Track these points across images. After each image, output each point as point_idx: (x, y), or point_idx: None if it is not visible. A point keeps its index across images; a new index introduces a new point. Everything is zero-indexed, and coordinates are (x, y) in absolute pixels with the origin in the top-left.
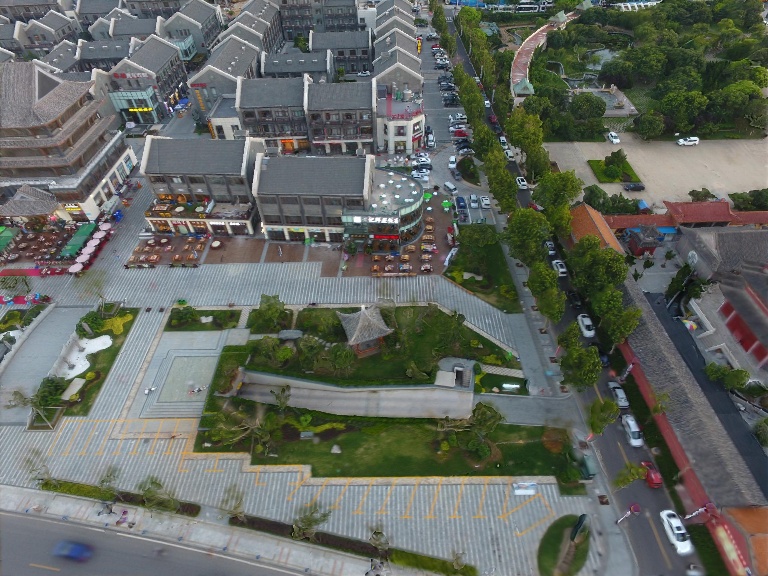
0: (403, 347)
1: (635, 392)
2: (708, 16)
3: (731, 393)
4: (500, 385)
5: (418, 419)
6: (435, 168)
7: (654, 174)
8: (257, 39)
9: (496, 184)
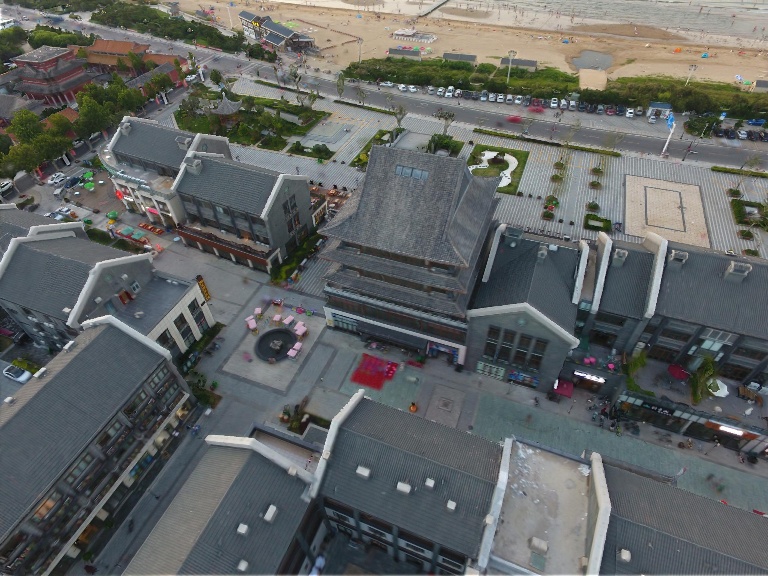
0: None
1: None
2: None
3: None
4: None
5: (237, 100)
6: None
7: None
8: None
9: None
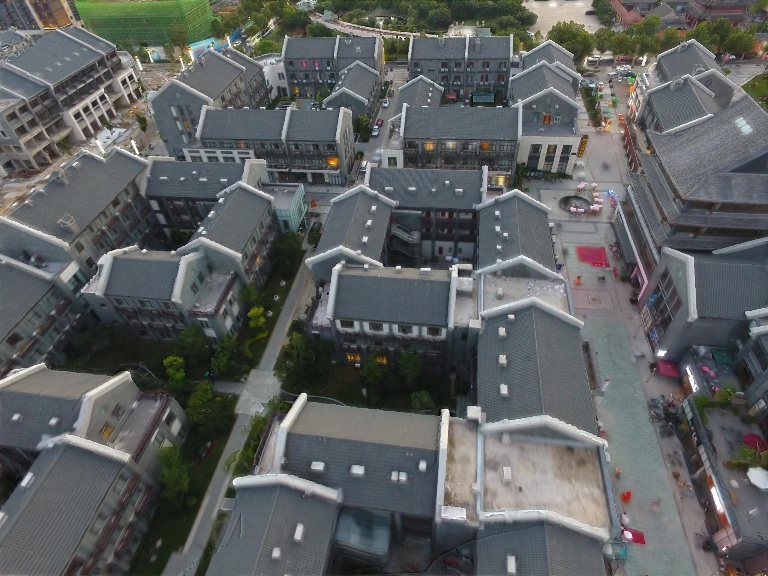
0: None
1: None
2: None
3: None
4: None
5: None
6: None
7: None
8: (350, 119)
9: None
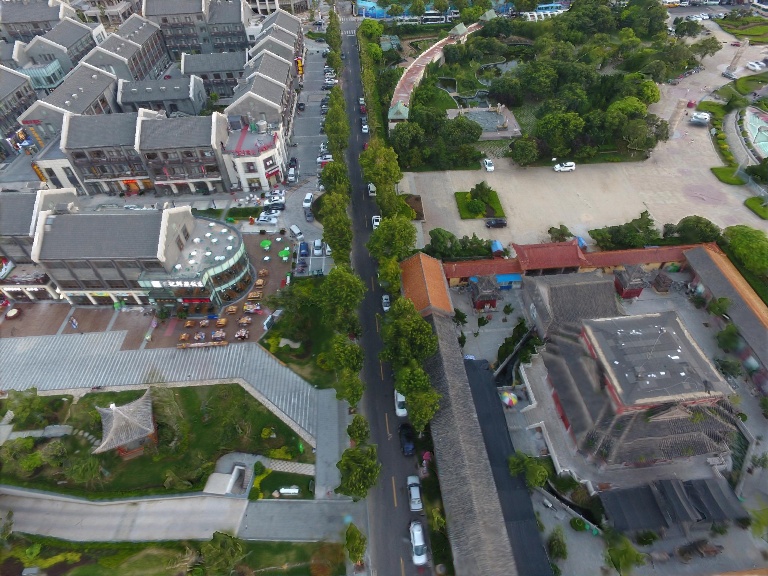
0: (174, 446)
1: (434, 489)
2: (612, 25)
3: (539, 486)
4: (283, 487)
5: (167, 543)
6: (289, 207)
7: (522, 206)
8: (122, 64)
9: (327, 233)
